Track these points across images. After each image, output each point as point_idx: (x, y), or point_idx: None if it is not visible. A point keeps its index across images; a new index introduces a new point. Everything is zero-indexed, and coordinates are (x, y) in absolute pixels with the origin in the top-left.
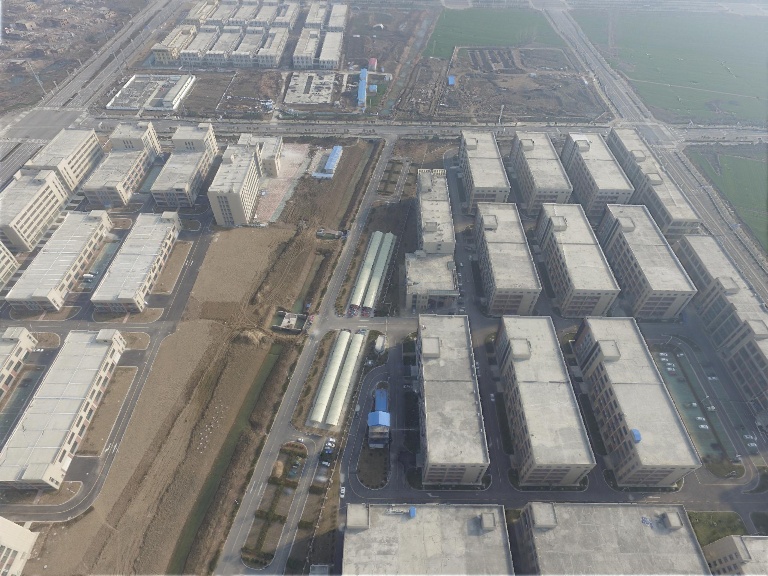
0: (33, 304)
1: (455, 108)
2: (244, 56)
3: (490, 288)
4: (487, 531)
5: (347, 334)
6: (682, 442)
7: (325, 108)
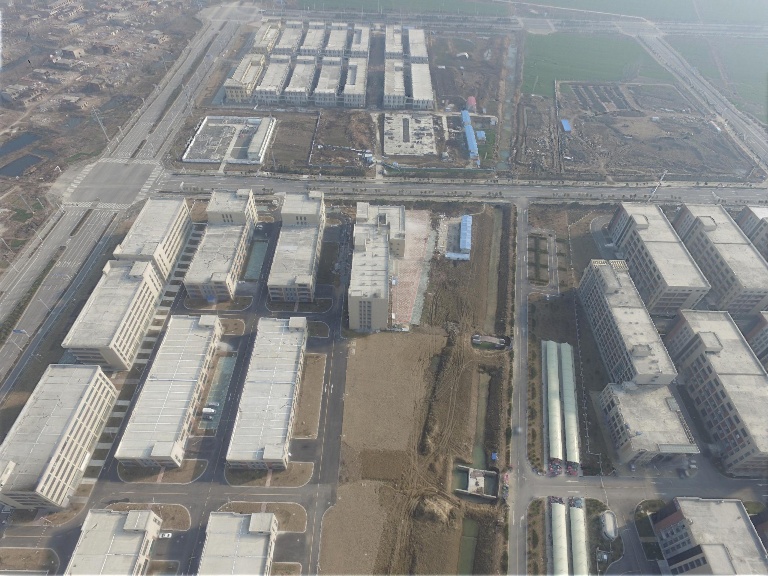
0: (149, 461)
1: (582, 162)
2: (328, 94)
3: (732, 440)
4: None
5: (562, 508)
6: None
7: (433, 161)
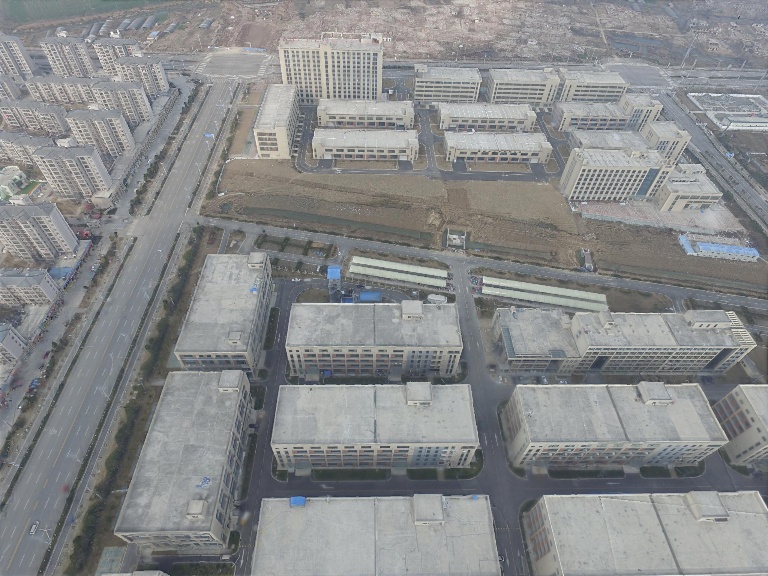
0: None
1: None
2: None
3: None
4: None
5: (444, 274)
6: (285, 571)
7: None
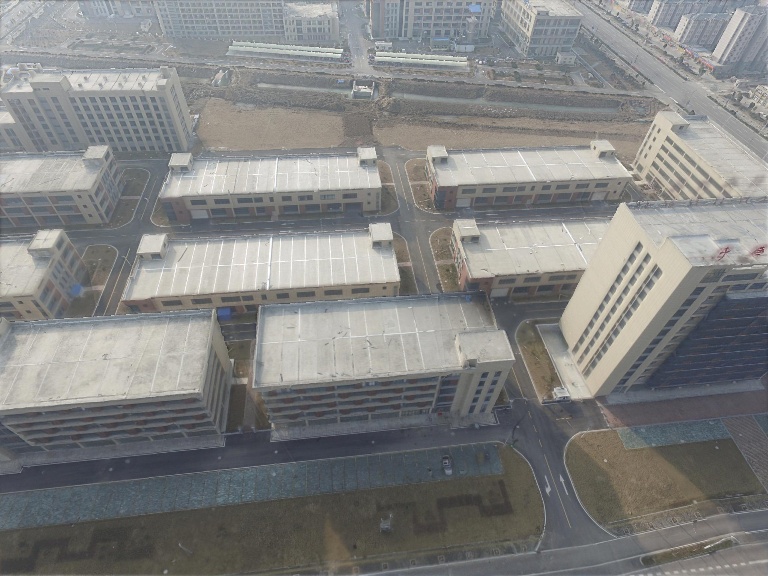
0: None
1: None
2: None
3: None
4: None
5: None
6: None
7: None
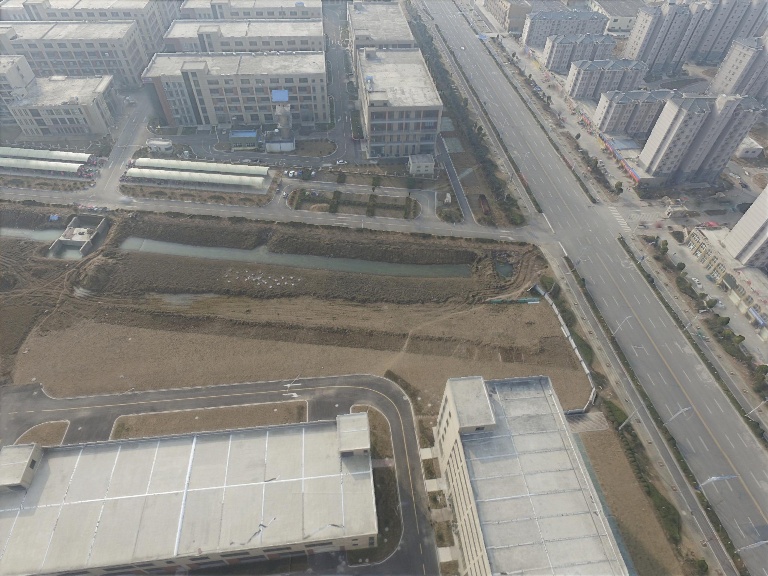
0: None
1: None
2: None
3: (110, 62)
4: (377, 56)
5: (134, 169)
6: None
7: None
